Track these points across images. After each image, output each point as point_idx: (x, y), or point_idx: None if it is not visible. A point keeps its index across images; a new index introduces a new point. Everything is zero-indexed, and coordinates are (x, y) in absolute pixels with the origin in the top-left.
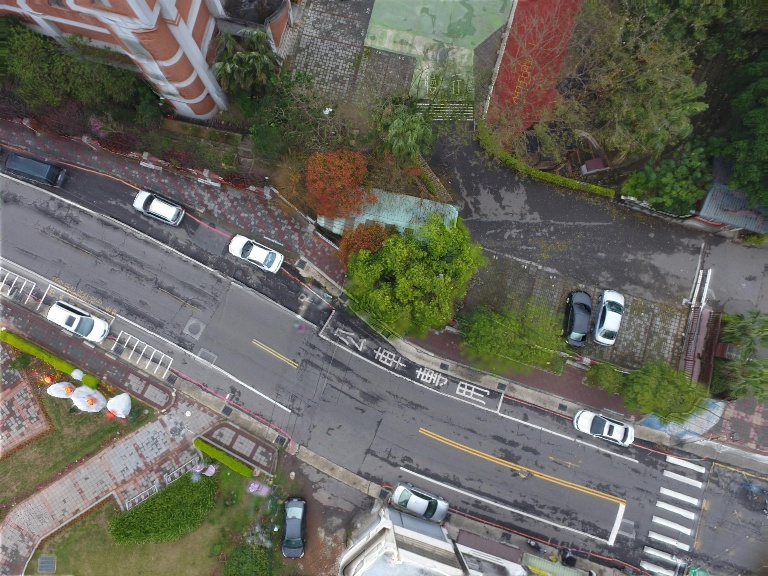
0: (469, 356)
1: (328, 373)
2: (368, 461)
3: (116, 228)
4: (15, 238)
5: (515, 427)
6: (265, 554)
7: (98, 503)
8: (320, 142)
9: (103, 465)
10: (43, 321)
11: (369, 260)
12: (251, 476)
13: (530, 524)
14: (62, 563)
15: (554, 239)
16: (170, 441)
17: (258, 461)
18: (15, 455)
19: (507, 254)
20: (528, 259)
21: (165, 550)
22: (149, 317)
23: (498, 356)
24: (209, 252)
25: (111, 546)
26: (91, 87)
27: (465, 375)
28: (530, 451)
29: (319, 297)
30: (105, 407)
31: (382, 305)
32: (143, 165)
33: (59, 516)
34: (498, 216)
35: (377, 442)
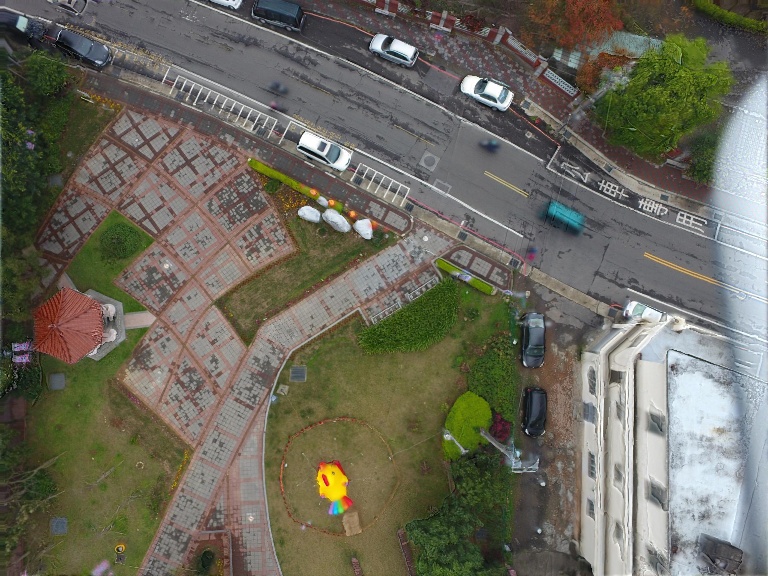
0: (688, 188)
1: (557, 202)
2: (597, 282)
3: (352, 70)
4: (257, 78)
5: (732, 254)
6: (510, 361)
7: (345, 318)
8: None
9: (347, 285)
10: (286, 153)
11: (625, 75)
12: (489, 294)
13: (749, 342)
14: (312, 373)
15: (759, 86)
16: (409, 263)
17: (495, 281)
18: (265, 274)
19: (715, 100)
20: (735, 104)
21: (412, 360)
22: (386, 151)
23: (715, 188)
24: (440, 92)
25: (361, 356)
26: None
27: (684, 206)
28: (747, 276)
29: (544, 134)
30: (349, 231)
31: (662, 97)
32: (378, 12)
33: (307, 331)
34: (706, 65)
35: (605, 265)
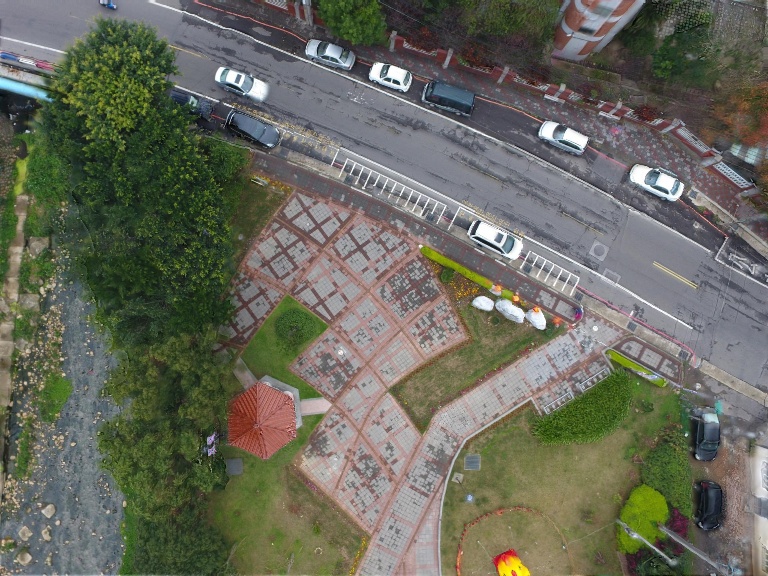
0: None
1: (726, 294)
2: (765, 375)
3: (520, 156)
4: (425, 163)
5: None
6: (685, 455)
7: (518, 408)
8: (761, 74)
9: (519, 374)
10: (456, 240)
11: None
12: None
13: None
14: (487, 462)
15: None
16: (580, 353)
17: (665, 372)
18: (438, 362)
19: None
20: None
21: (586, 451)
22: (555, 239)
23: None
24: (608, 180)
25: (536, 446)
26: (539, 18)
27: None
28: None
29: (711, 225)
30: None
31: None
32: (547, 98)
33: (480, 419)
34: None
35: None
